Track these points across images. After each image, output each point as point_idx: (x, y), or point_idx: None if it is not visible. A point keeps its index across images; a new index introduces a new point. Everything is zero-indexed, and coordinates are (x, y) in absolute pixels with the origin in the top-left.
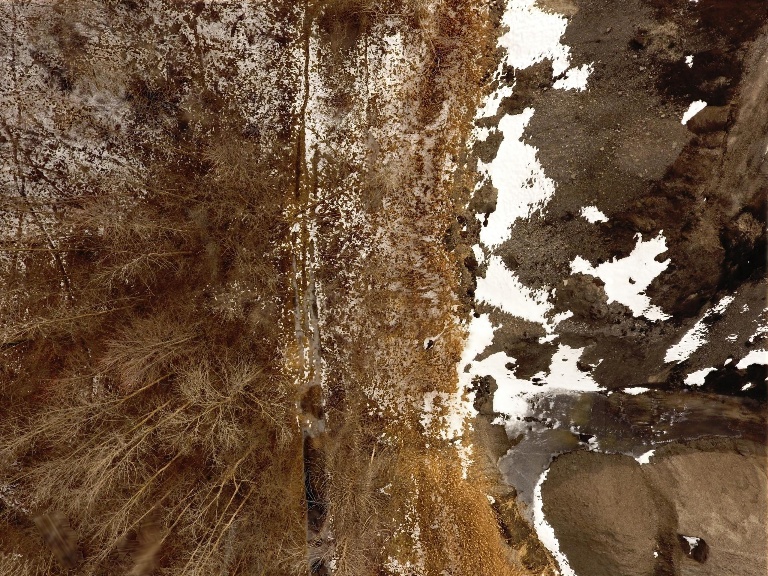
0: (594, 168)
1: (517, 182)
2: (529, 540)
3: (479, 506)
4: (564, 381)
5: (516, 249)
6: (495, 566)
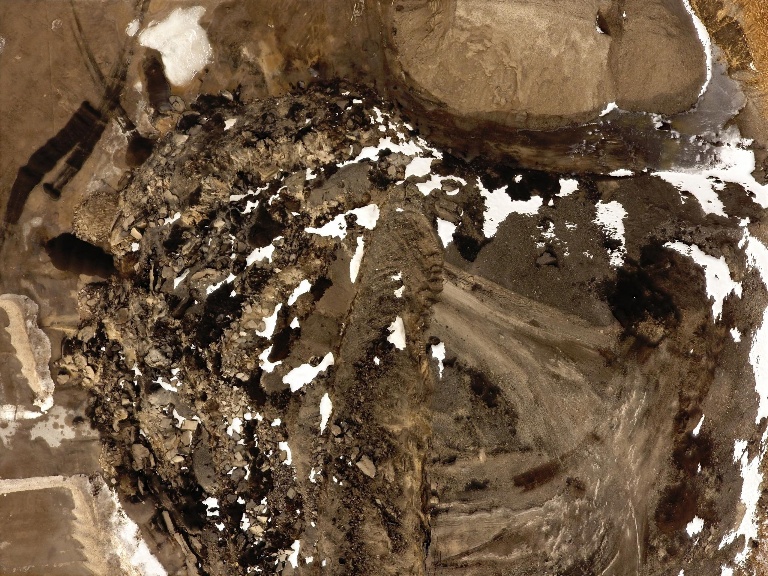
0: (738, 375)
1: (762, 360)
2: (715, 26)
3: (764, 60)
4: (693, 181)
5: (763, 302)
6: (758, 1)
